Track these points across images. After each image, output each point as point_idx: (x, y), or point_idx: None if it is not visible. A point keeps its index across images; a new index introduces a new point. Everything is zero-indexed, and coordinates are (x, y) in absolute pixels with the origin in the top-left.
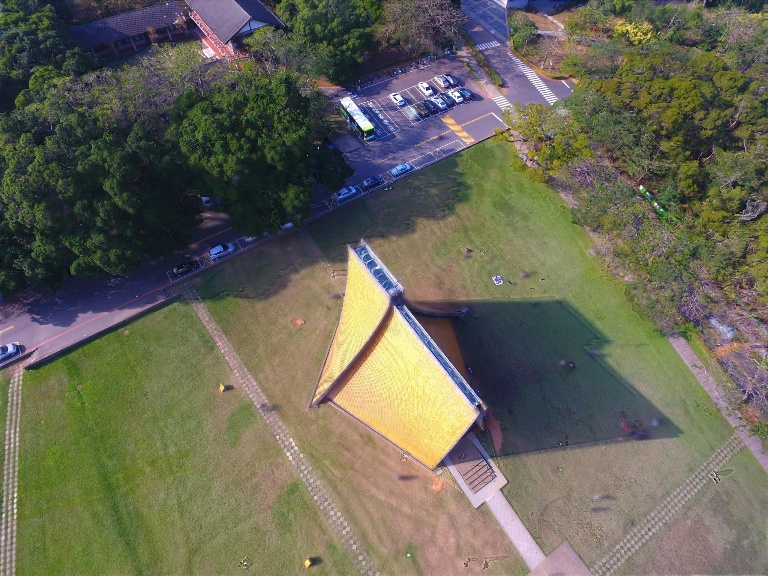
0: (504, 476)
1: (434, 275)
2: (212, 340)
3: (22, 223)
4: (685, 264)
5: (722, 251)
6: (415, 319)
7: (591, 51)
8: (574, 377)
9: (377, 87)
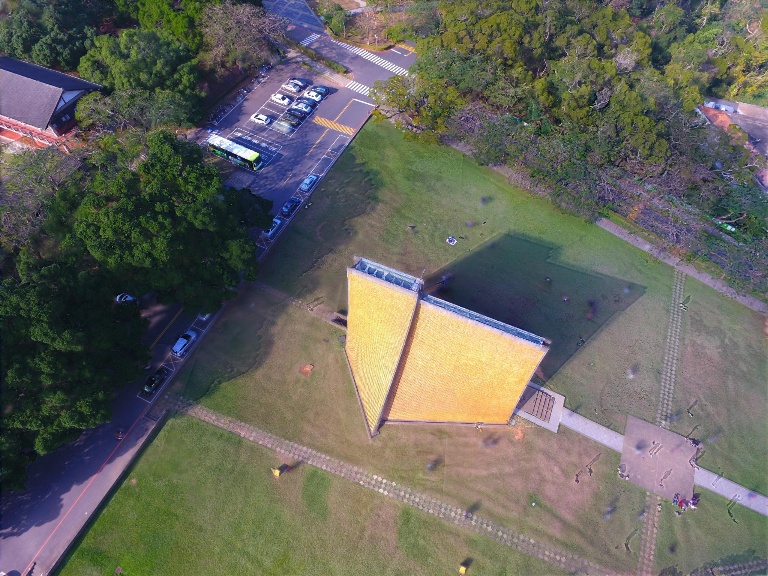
0: (559, 394)
1: (398, 263)
2: (233, 434)
3: None
4: (584, 159)
5: (603, 138)
6: (445, 302)
7: (409, 15)
8: (555, 288)
9: (232, 115)
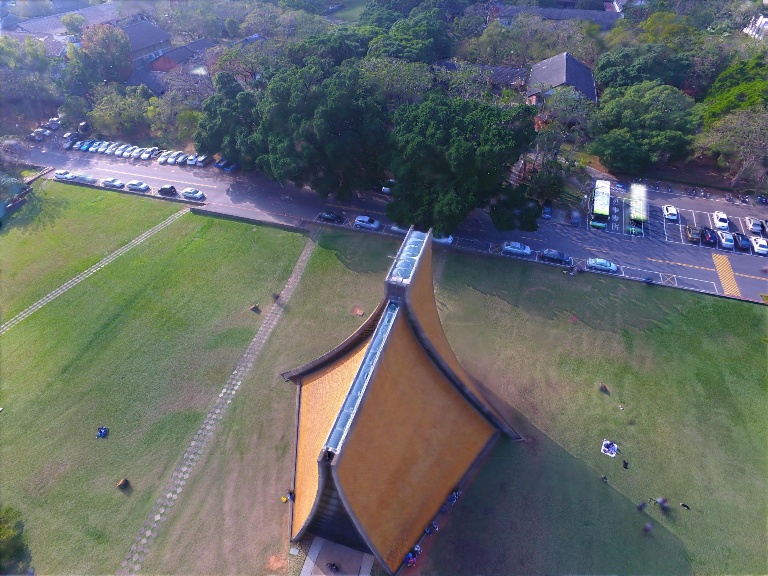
0: None
1: (530, 378)
2: (290, 273)
3: (259, 111)
4: None
5: None
6: (391, 325)
7: None
8: None
9: (657, 194)
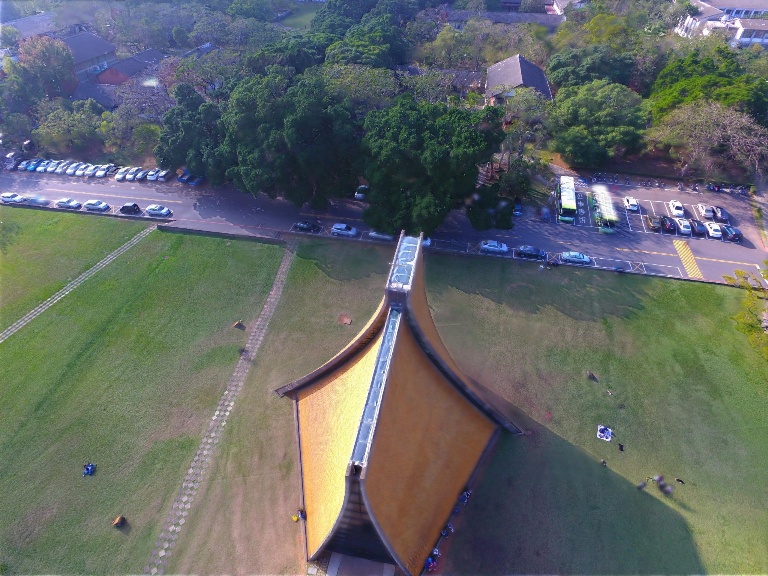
0: None
1: (522, 372)
2: (271, 286)
3: (224, 122)
4: None
5: None
6: (396, 331)
7: None
8: None
9: (617, 187)
